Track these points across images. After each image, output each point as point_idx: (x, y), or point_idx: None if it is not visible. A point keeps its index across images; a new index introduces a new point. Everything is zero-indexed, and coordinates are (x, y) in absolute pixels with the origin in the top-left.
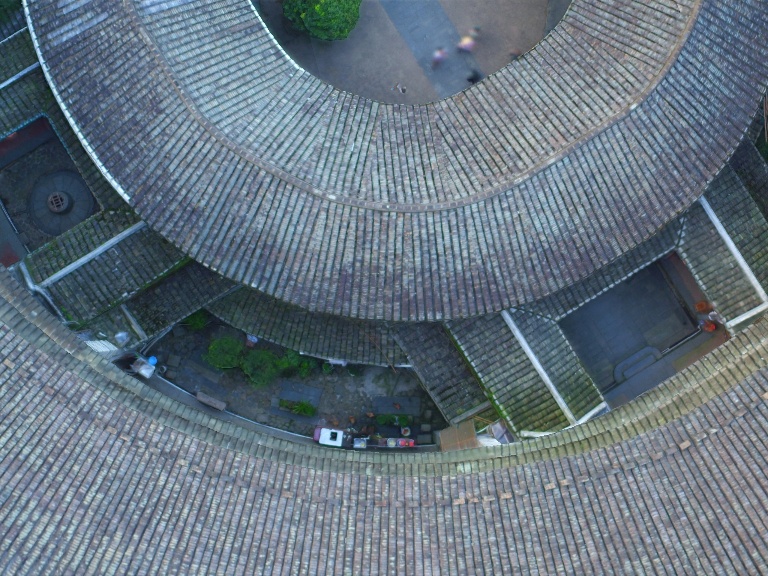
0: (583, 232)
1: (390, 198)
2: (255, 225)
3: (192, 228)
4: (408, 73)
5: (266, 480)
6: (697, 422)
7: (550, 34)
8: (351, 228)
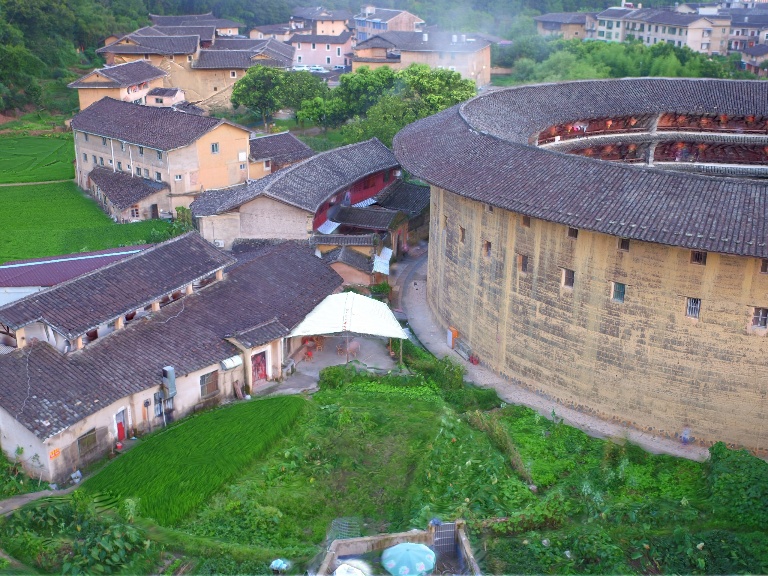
0: None
1: None
2: None
3: None
4: None
5: None
6: (765, 112)
7: None
8: None
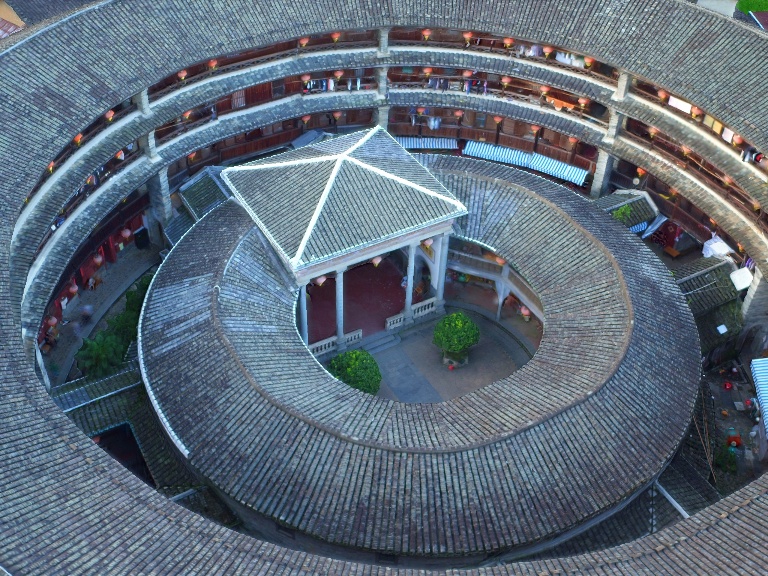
0: (563, 487)
1: (402, 445)
2: (290, 466)
3: (237, 472)
4: None
5: (288, 560)
6: (668, 536)
7: (523, 367)
8: (369, 466)
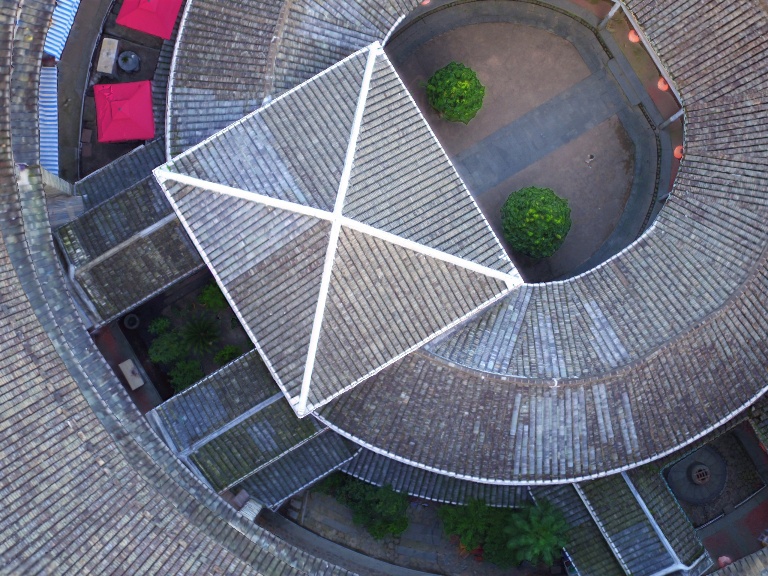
0: None
1: None
2: None
3: None
4: (576, 153)
5: None
6: None
7: (622, 0)
8: None
